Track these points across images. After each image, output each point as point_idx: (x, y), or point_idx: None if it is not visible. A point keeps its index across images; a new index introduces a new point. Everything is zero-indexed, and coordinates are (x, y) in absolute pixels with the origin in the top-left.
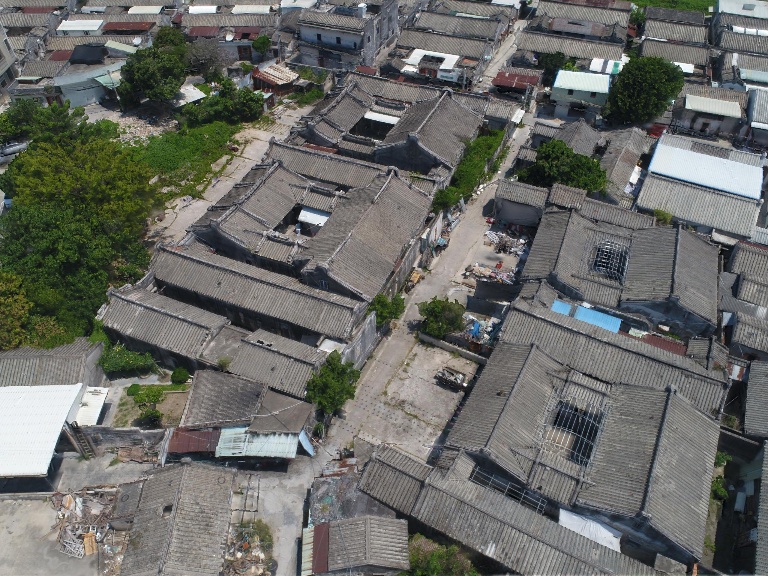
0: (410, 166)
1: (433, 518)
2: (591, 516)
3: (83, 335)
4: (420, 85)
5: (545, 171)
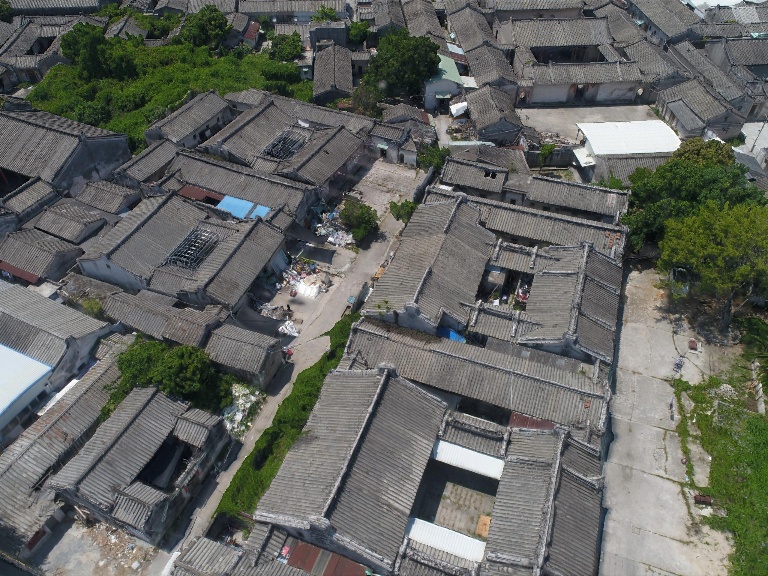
0: None
1: None
2: None
3: None
4: None
5: None
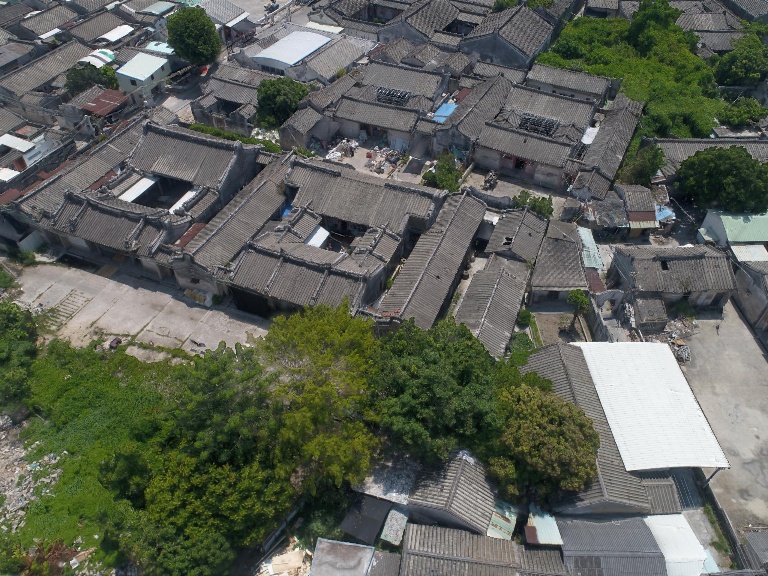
0: (243, 176)
1: (611, 172)
2: (585, 130)
3: None
4: (90, 153)
5: (287, 101)
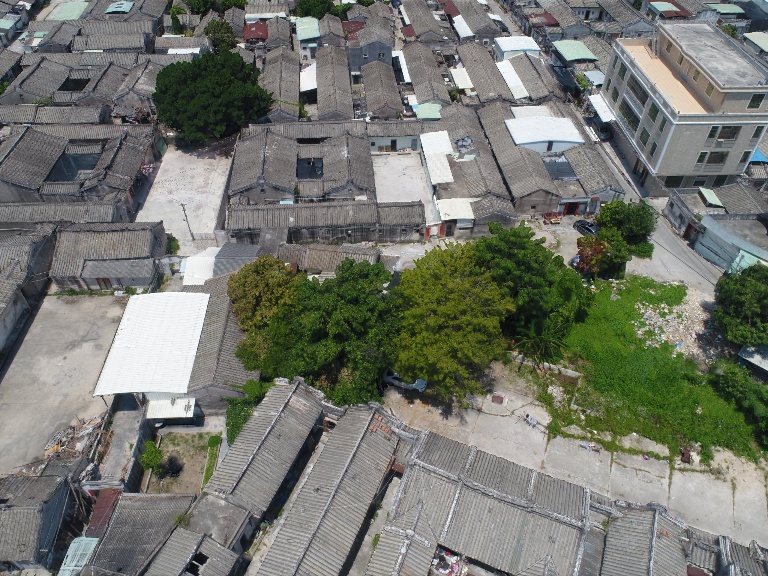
0: None
1: None
2: None
3: (268, 376)
4: None
5: None
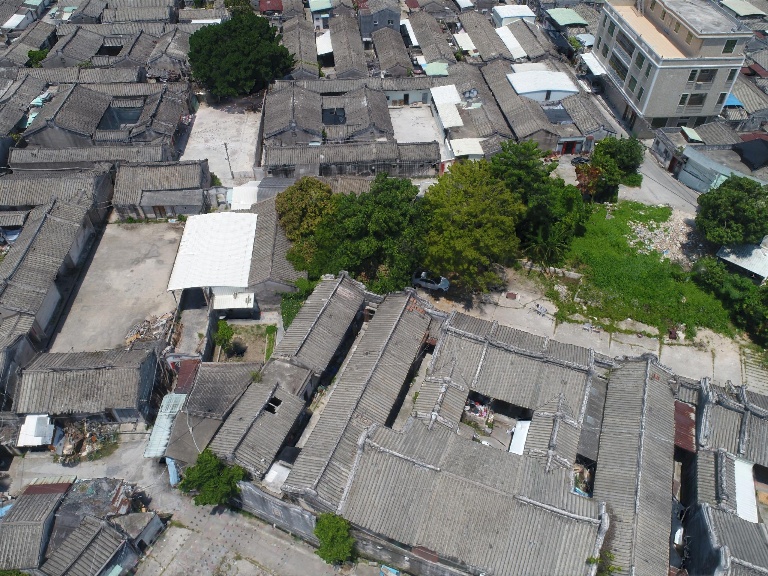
0: (697, 575)
1: None
2: None
3: (314, 276)
4: None
5: None
